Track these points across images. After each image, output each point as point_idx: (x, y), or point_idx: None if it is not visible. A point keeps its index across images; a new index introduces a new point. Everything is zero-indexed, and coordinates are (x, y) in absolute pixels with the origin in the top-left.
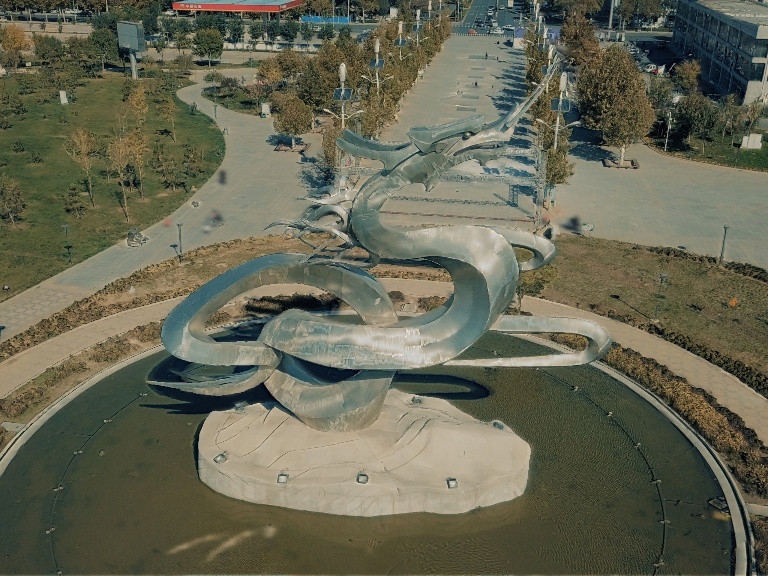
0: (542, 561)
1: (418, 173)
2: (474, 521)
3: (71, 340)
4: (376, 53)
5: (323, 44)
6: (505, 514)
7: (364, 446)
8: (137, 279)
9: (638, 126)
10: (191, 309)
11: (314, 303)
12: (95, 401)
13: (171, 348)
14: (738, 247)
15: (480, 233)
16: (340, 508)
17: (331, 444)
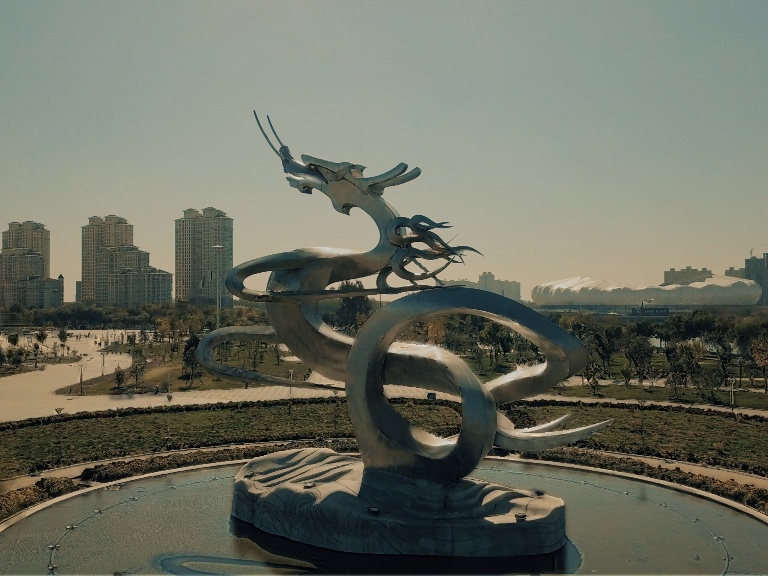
0: None
1: None
2: None
3: None
4: None
5: None
6: None
7: None
8: None
9: None
10: None
11: None
12: None
13: None
14: None
15: None
16: None
17: None
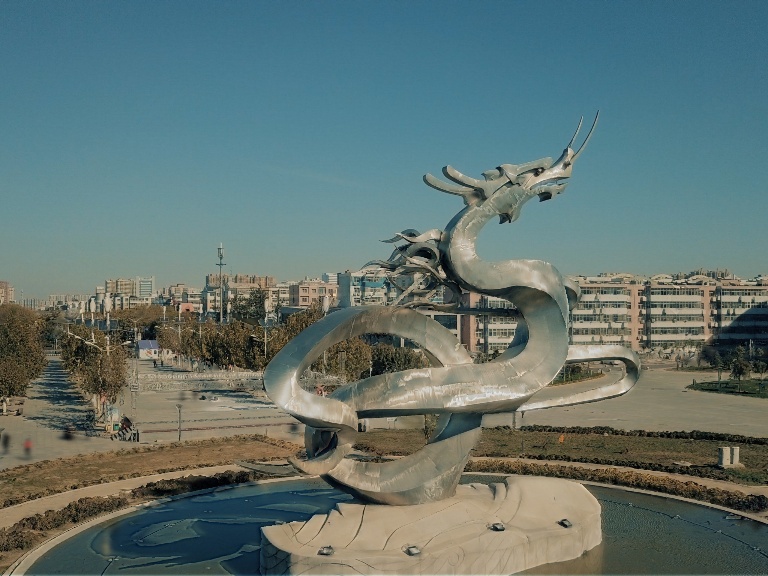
0: (681, 568)
1: (505, 204)
2: (583, 570)
3: None
4: (91, 313)
5: (5, 319)
6: (597, 562)
7: (471, 506)
8: None
9: (363, 359)
10: (292, 359)
11: (213, 480)
12: (53, 575)
13: (282, 402)
14: (510, 422)
15: (545, 266)
16: (480, 571)
17: (438, 511)
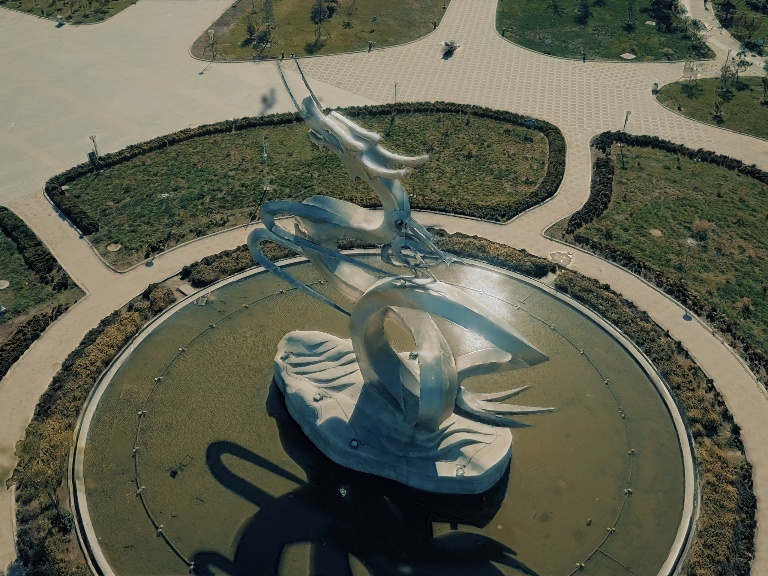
0: None
1: None
2: None
3: None
4: None
5: None
6: None
7: None
8: None
9: None
10: None
11: None
12: None
13: None
14: None
15: None
16: None
17: None
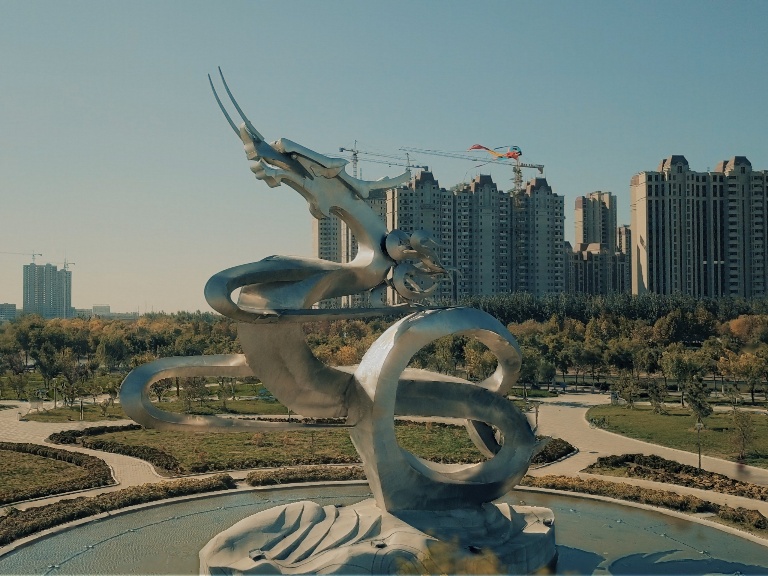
0: None
1: None
2: None
3: None
4: None
5: None
6: None
7: None
8: None
9: None
10: None
11: None
12: (720, 541)
13: None
14: None
15: None
16: None
17: None
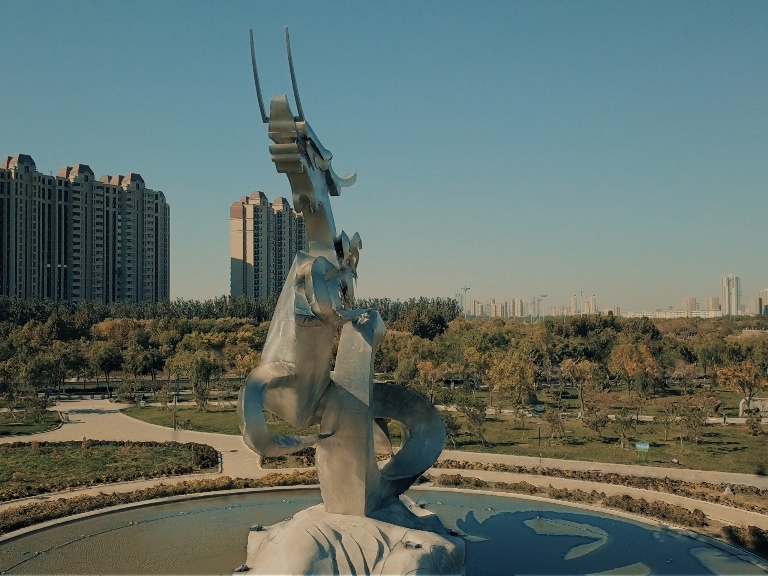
0: None
1: None
2: None
3: (587, 486)
4: None
5: None
6: None
7: None
8: (763, 492)
9: None
10: None
11: None
12: (476, 500)
13: None
14: None
15: None
16: None
17: None
